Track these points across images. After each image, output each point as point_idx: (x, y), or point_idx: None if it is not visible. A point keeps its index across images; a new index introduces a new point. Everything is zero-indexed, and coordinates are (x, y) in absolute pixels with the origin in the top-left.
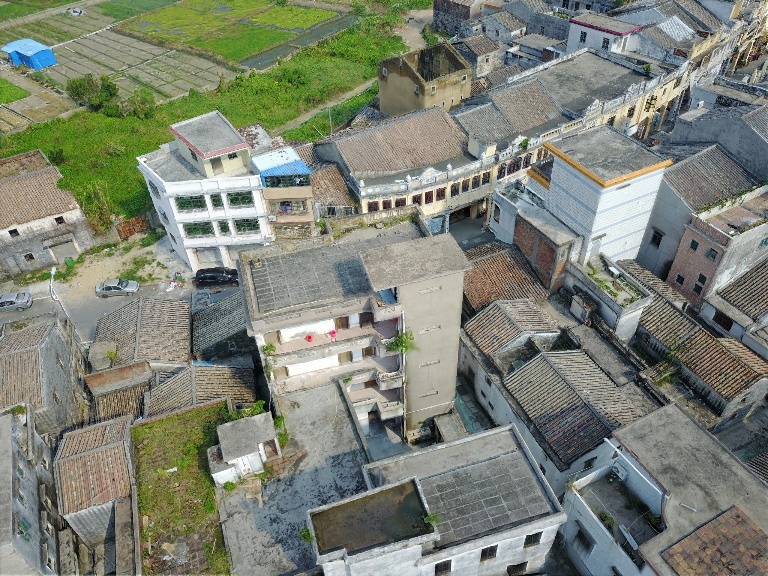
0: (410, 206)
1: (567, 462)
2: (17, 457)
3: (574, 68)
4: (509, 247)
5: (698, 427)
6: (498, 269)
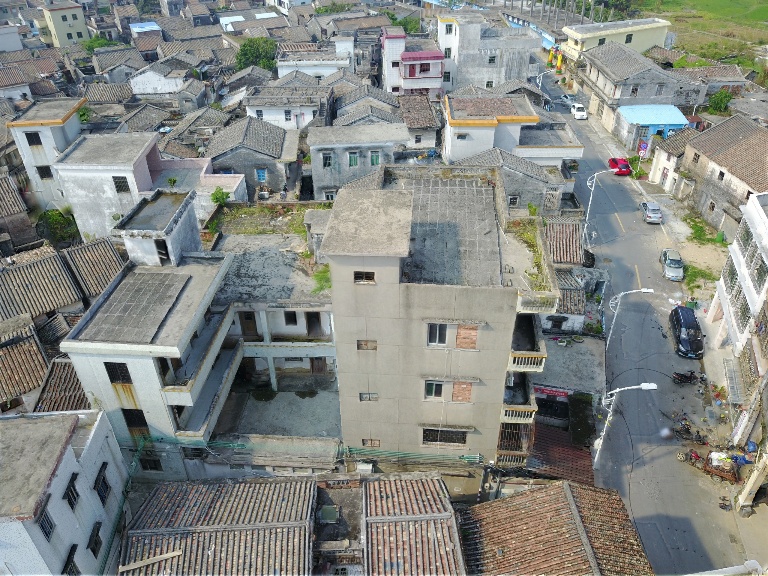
0: (553, 286)
1: (157, 487)
2: (378, 150)
3: None
4: None
5: None
6: (558, 575)
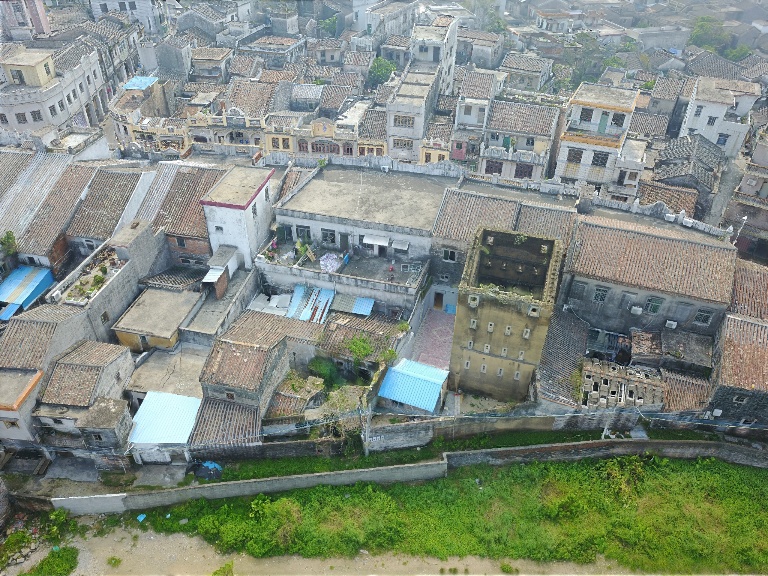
0: None
1: None
2: None
3: (338, 208)
4: (642, 183)
5: (698, 95)
6: None
